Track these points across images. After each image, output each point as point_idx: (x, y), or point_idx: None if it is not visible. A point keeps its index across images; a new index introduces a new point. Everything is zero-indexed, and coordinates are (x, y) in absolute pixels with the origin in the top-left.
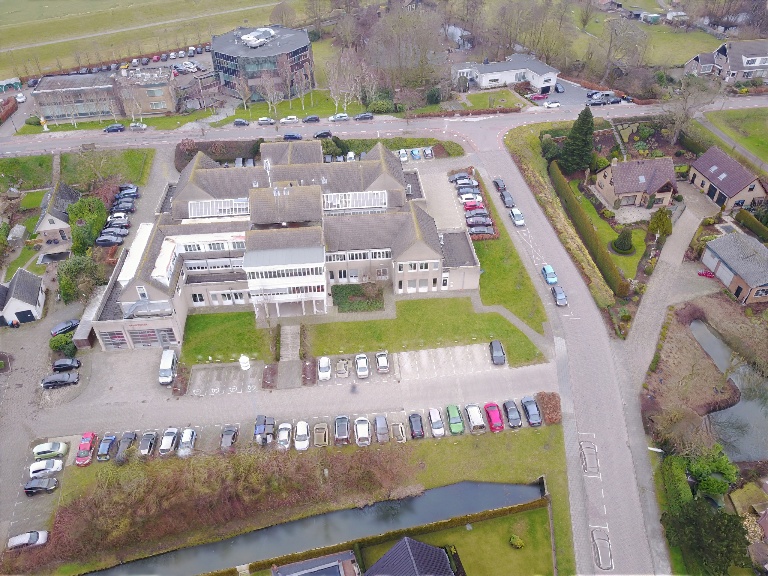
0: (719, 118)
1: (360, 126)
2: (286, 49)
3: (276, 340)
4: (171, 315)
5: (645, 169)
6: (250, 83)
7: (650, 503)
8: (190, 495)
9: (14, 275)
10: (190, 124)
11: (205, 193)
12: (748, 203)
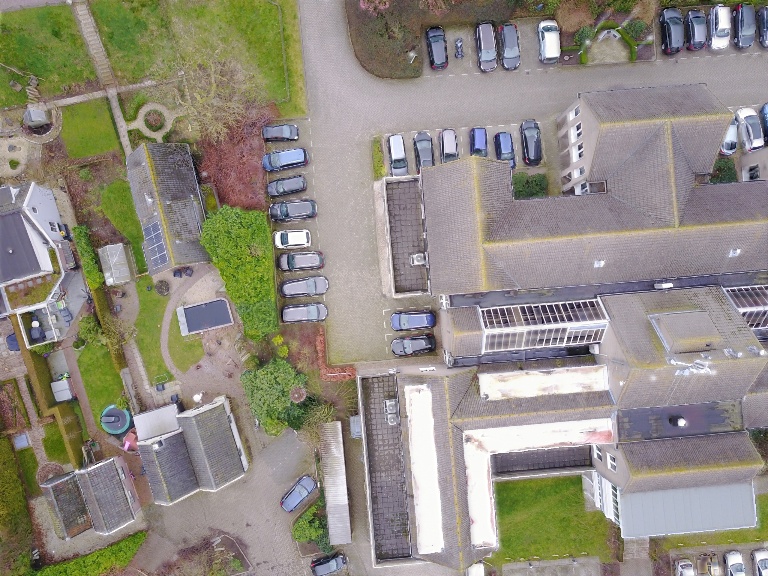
0: None
1: None
2: None
3: (618, 535)
4: None
5: None
6: None
7: None
8: None
9: (183, 417)
10: None
11: None
12: None
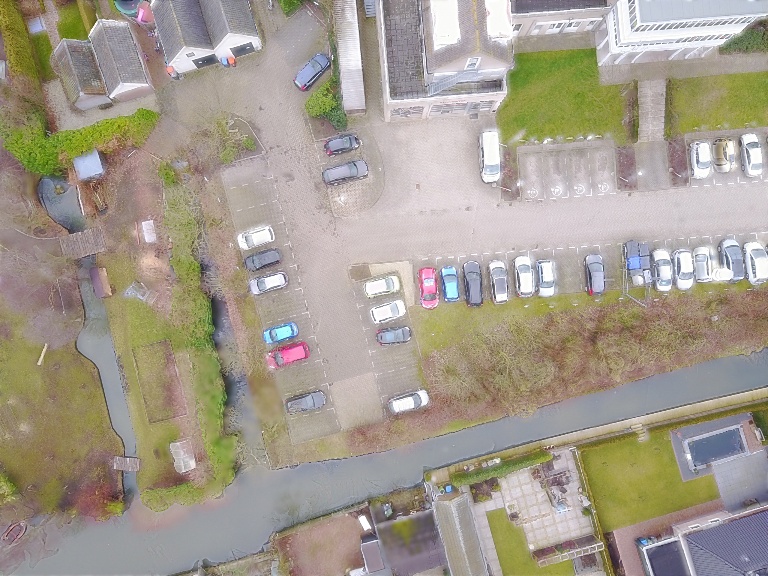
0: None
1: None
2: None
3: (633, 109)
4: (502, 87)
5: None
6: None
7: None
8: (599, 379)
9: None
10: None
11: None
12: None
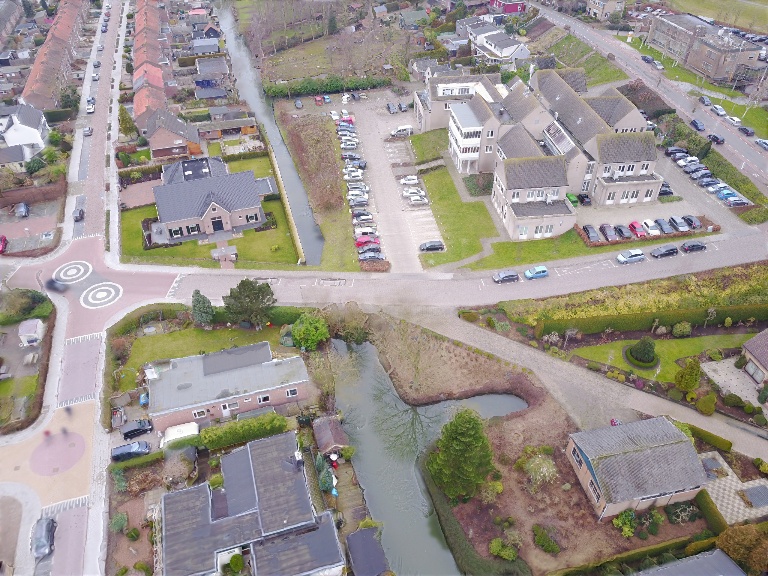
0: None
1: (760, 158)
2: None
3: None
4: None
5: None
6: None
7: None
8: None
9: None
10: (685, 84)
11: (538, 85)
12: None
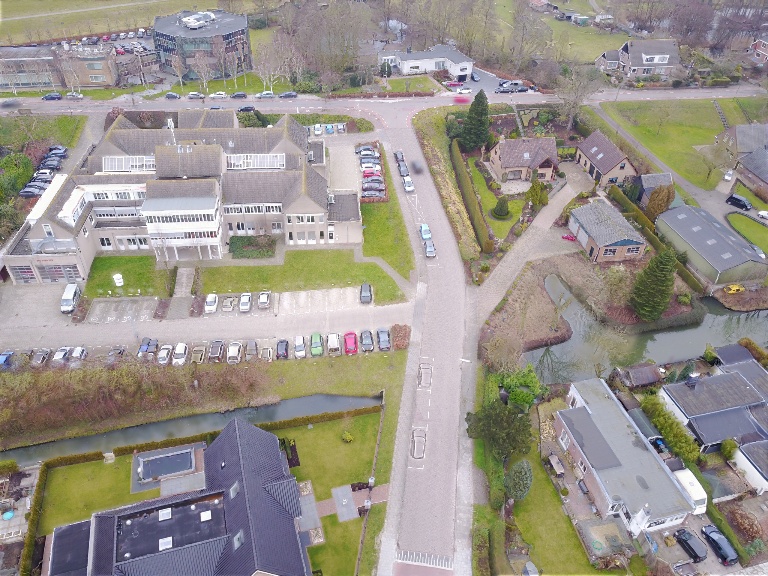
0: (613, 108)
1: (283, 103)
2: (223, 31)
3: (172, 279)
4: (75, 253)
5: (530, 147)
6: (188, 62)
7: (468, 411)
8: (66, 392)
9: None
10: (125, 96)
11: (120, 151)
12: (621, 180)
